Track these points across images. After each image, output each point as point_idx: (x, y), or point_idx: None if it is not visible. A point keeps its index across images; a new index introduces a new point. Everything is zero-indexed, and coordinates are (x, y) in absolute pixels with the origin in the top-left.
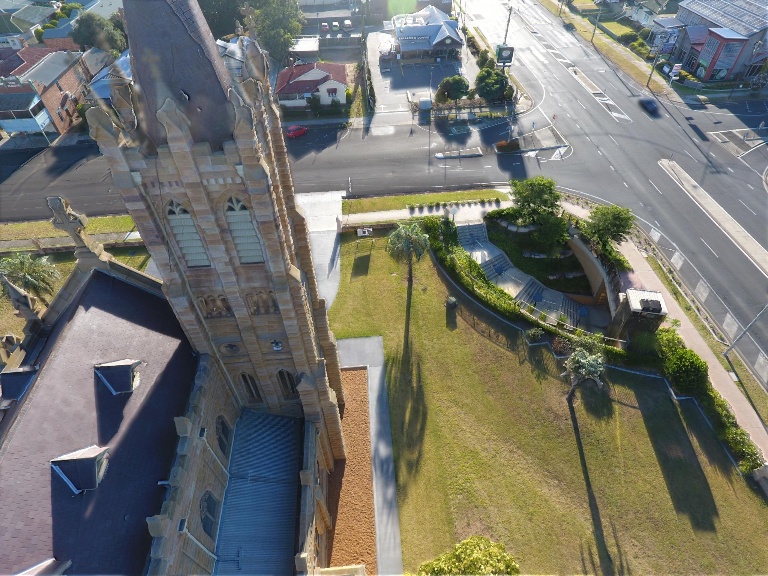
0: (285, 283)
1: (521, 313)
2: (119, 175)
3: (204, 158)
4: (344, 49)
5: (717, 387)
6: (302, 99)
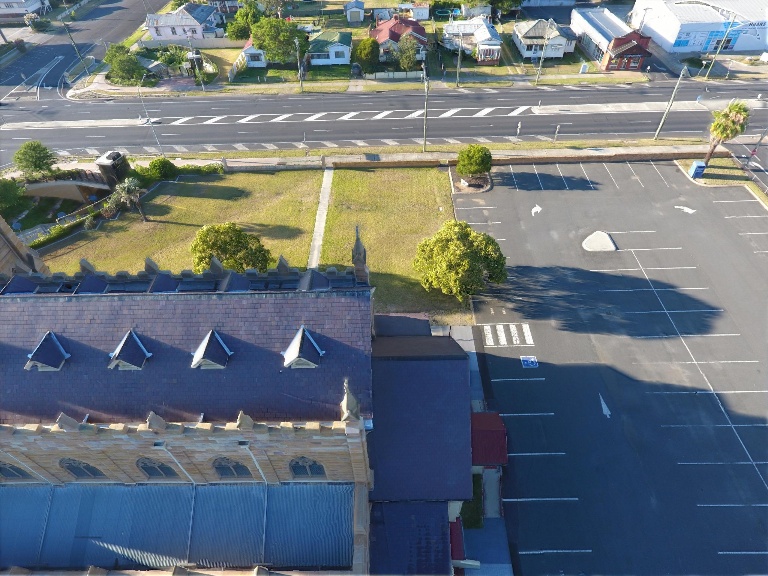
0: None
1: (67, 226)
2: None
3: None
4: None
5: (180, 166)
6: None
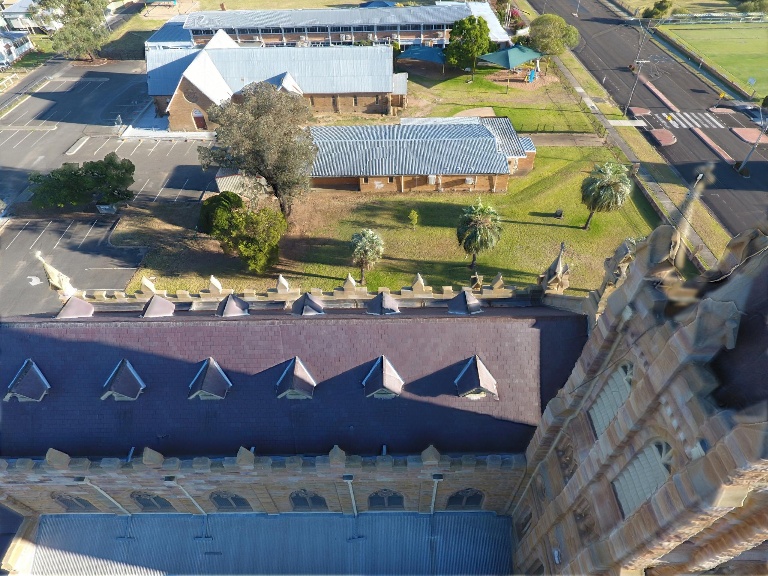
0: (603, 562)
1: None
2: (620, 295)
3: (688, 388)
4: None
5: None
6: None
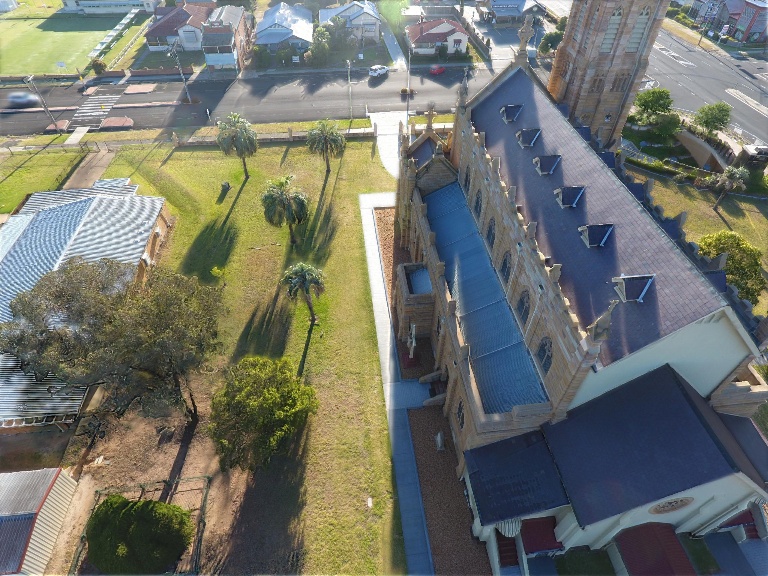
0: (646, 63)
1: (666, 168)
2: None
3: None
4: (439, 17)
5: None
6: (432, 48)
